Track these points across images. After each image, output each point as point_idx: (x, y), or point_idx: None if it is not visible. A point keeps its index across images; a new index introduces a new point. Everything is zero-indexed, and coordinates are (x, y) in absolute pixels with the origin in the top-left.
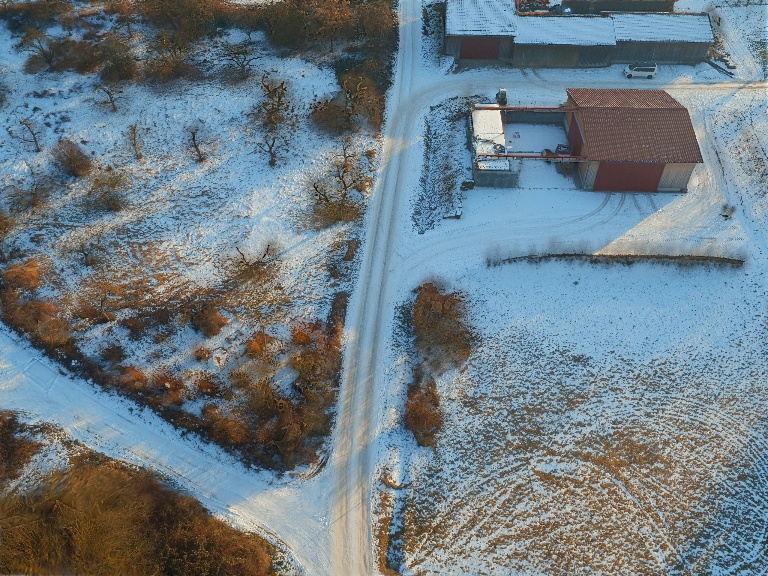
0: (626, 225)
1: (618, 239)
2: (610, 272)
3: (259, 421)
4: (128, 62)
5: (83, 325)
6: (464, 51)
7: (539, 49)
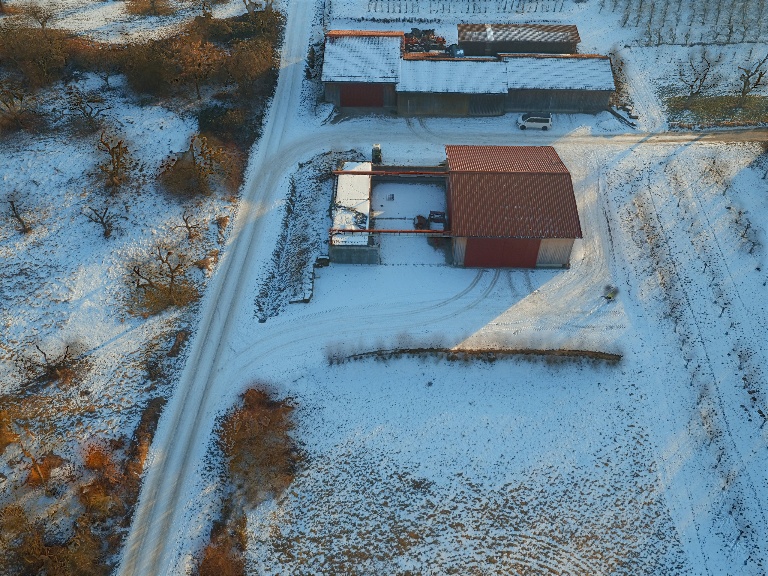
0: (495, 310)
1: (483, 329)
2: (469, 371)
3: (25, 575)
4: None
5: None
6: (345, 98)
7: (425, 97)
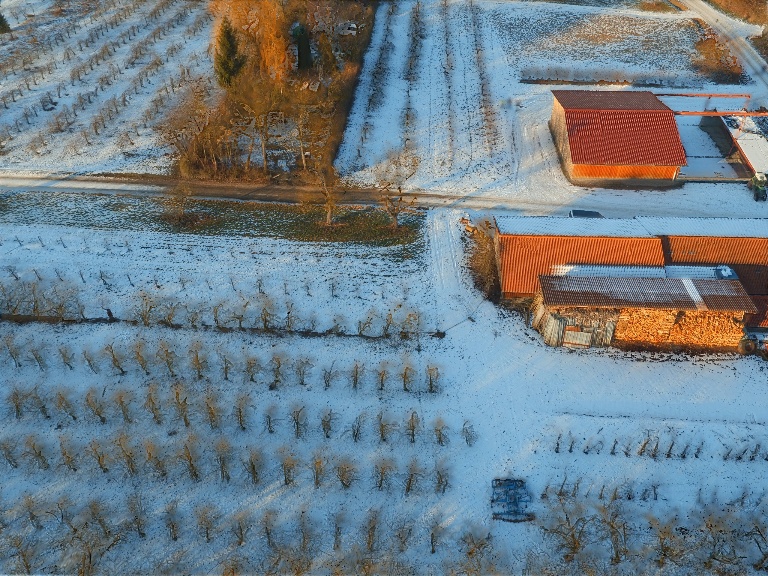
0: None
1: None
2: None
3: None
4: None
5: None
6: None
7: None
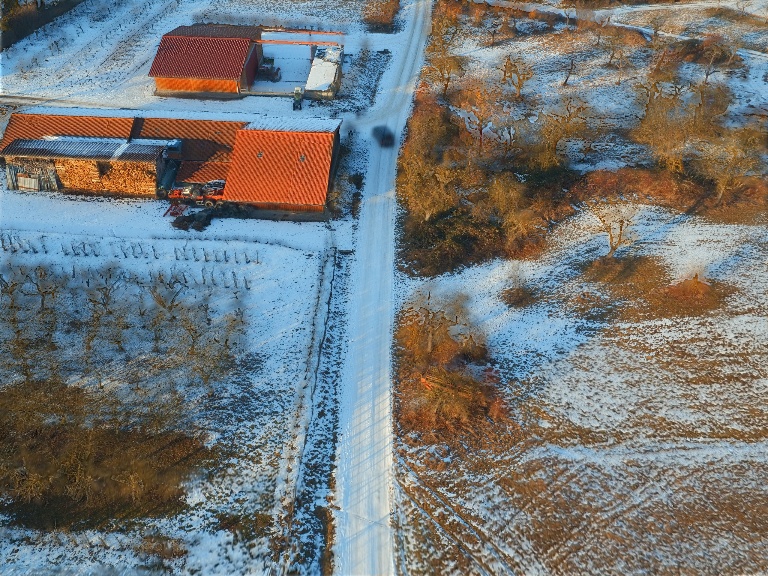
0: None
1: None
2: None
3: (468, 10)
4: None
5: (578, 30)
6: None
7: None
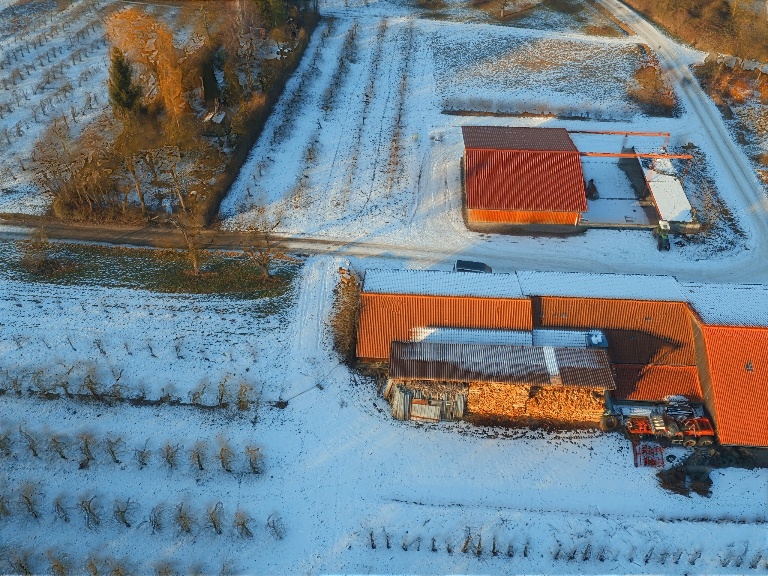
0: None
1: None
2: None
3: (736, 79)
4: None
5: None
6: None
7: None
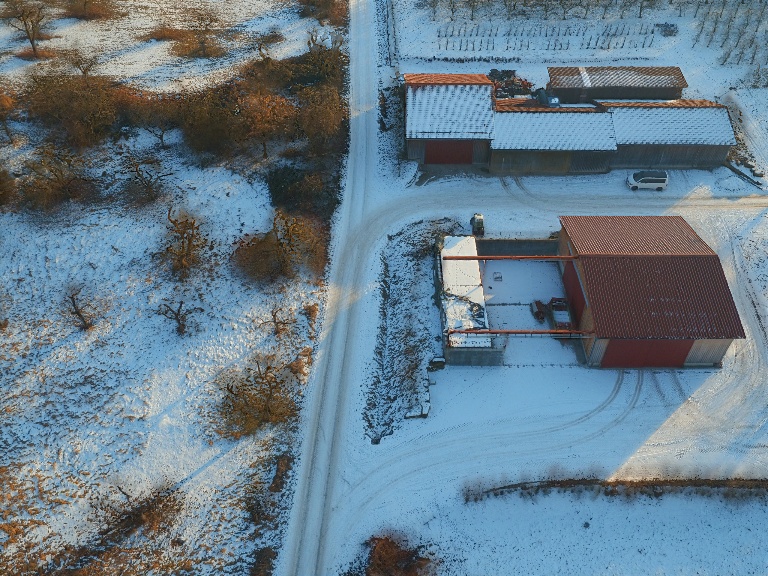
0: (648, 426)
1: (639, 451)
2: (632, 508)
3: None
4: (4, 179)
5: None
6: (430, 155)
7: (522, 154)
